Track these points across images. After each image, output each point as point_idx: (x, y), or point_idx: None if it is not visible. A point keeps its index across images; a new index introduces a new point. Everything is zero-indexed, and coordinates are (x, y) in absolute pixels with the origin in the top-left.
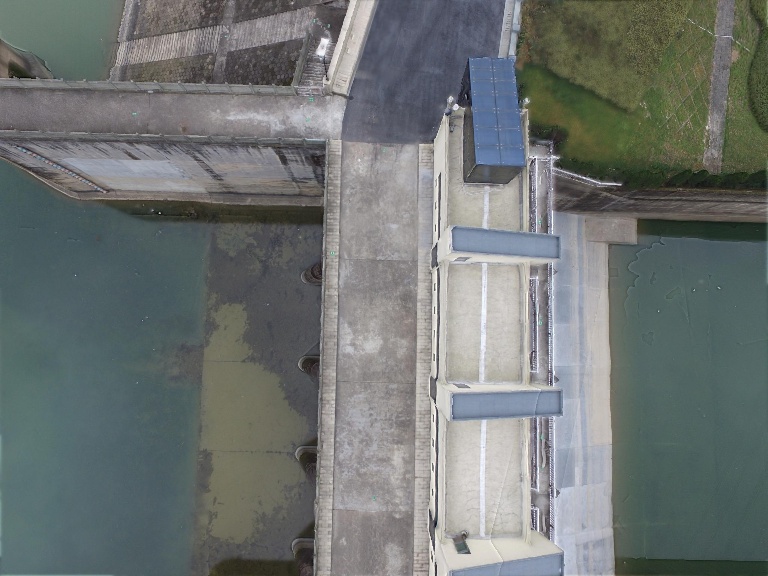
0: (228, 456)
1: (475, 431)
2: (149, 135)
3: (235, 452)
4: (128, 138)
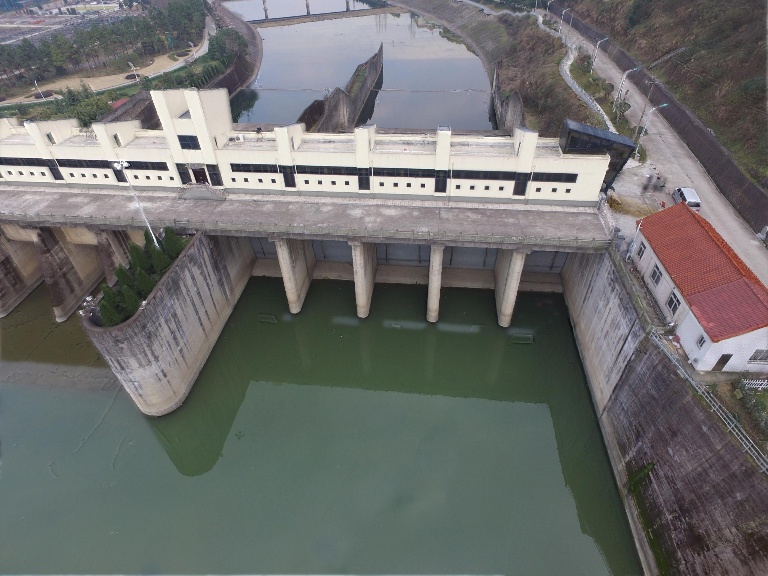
0: (27, 363)
1: (7, 142)
2: None
3: (27, 358)
4: None
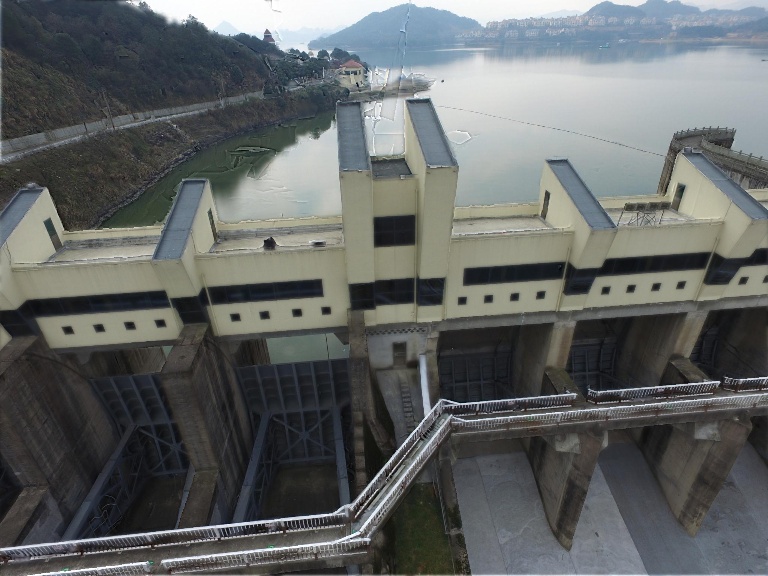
0: None
1: None
2: (762, 170)
3: None
4: (748, 171)
